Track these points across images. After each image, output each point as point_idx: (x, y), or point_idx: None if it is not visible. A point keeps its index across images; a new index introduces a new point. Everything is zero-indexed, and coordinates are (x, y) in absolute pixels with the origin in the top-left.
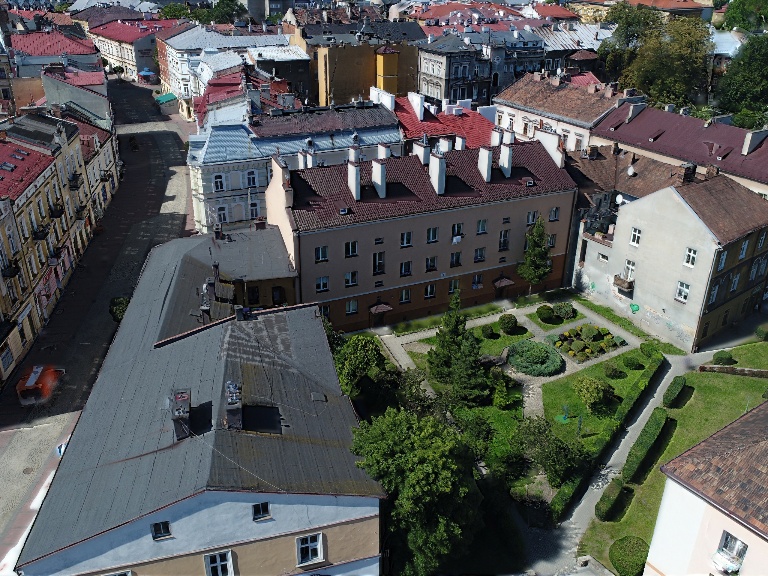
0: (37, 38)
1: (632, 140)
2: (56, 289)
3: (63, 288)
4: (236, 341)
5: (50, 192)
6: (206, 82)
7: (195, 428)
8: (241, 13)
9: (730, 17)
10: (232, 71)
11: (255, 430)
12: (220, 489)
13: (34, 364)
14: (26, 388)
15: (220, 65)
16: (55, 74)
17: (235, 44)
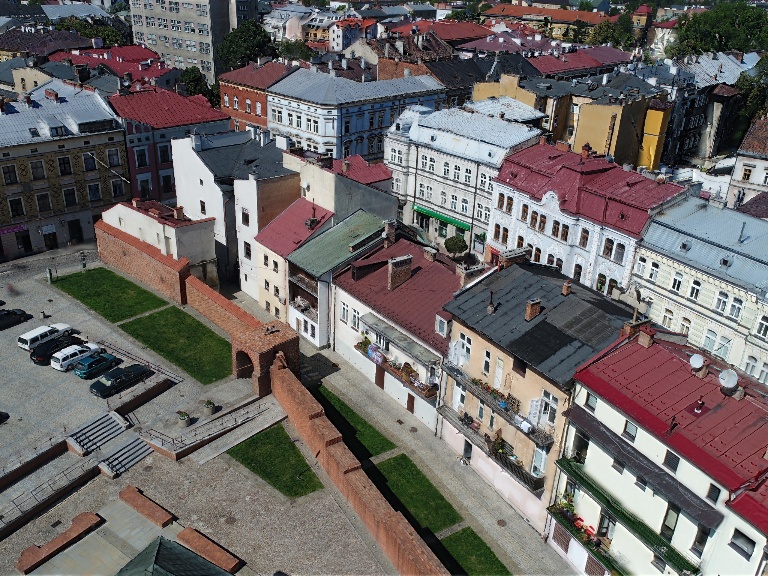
0: (146, 100)
1: None
2: None
3: None
4: None
5: None
6: (475, 158)
7: None
8: (266, 42)
9: (684, 35)
10: (528, 144)
11: None
12: None
13: None
14: None
15: (488, 134)
16: (330, 169)
17: (381, 93)
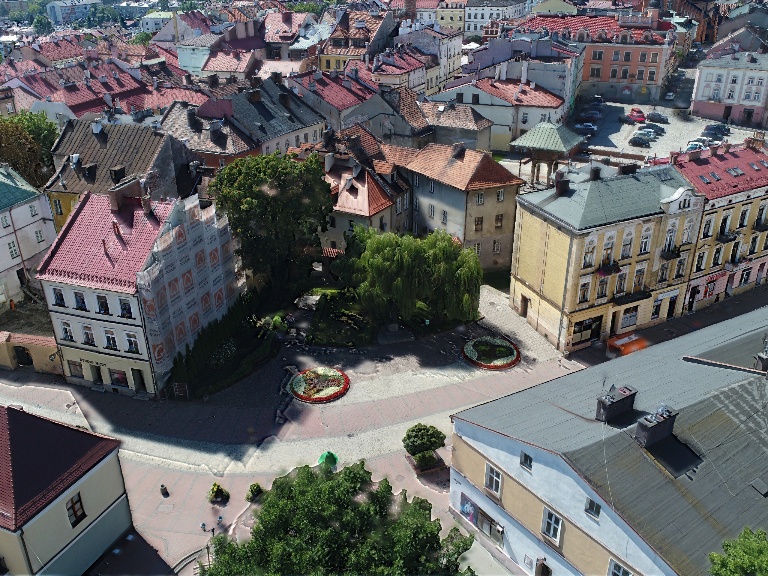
0: None
1: None
2: (722, 292)
3: (732, 295)
4: (741, 392)
5: (767, 207)
6: None
7: (615, 420)
8: None
9: None
10: None
11: (656, 457)
12: (568, 462)
13: (648, 336)
14: (613, 344)
15: None
16: None
17: None
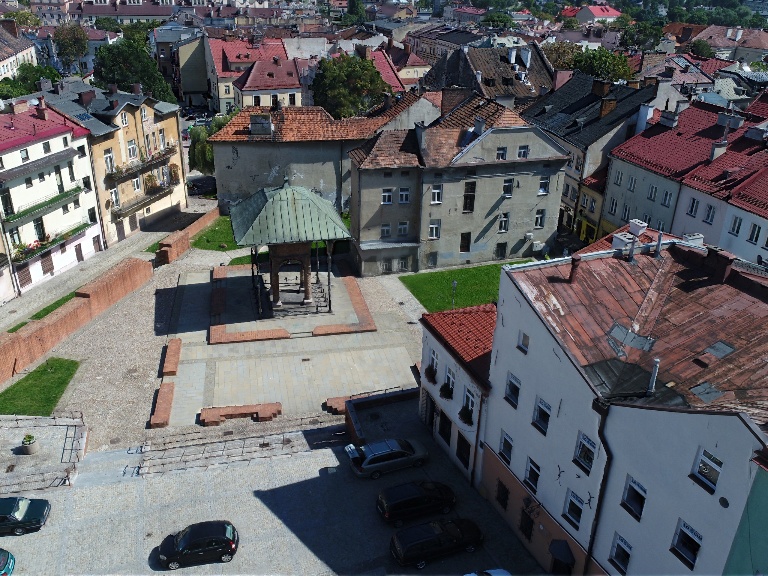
0: None
1: None
2: None
3: None
4: None
5: None
6: None
7: None
8: None
9: None
10: None
11: None
12: None
13: None
14: None
15: None
16: None
17: None
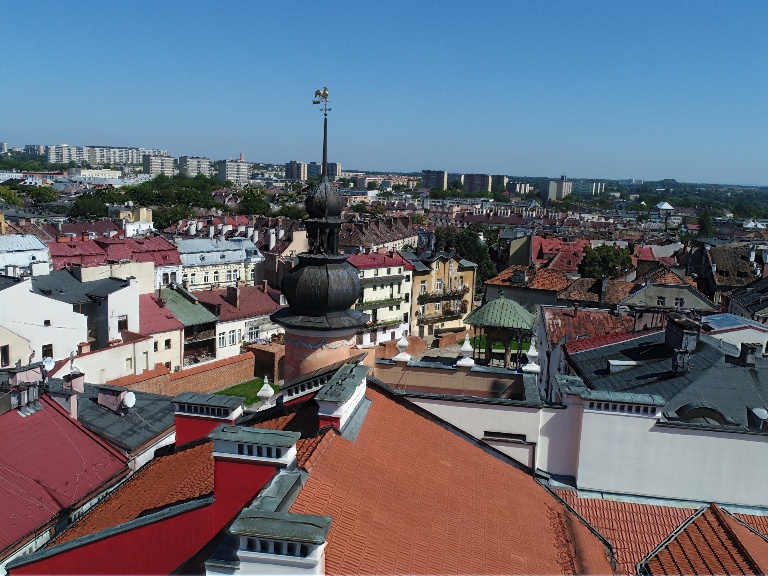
0: None
1: None
2: None
3: None
4: None
5: None
6: (23, 266)
7: None
8: None
9: None
10: None
11: None
12: None
13: None
14: None
15: (8, 246)
16: None
17: None
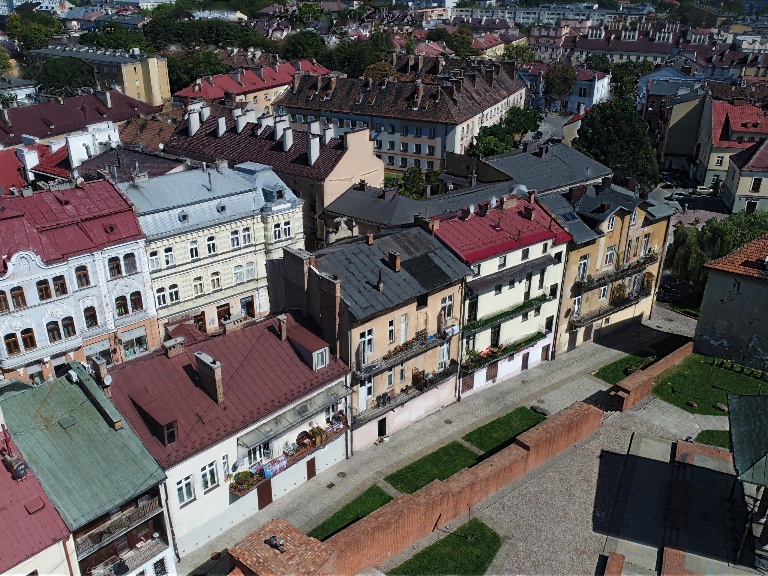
0: None
1: (41, 134)
2: None
3: None
4: None
5: None
6: None
7: None
8: None
9: None
10: None
11: None
12: None
13: None
14: None
15: None
16: None
17: None
